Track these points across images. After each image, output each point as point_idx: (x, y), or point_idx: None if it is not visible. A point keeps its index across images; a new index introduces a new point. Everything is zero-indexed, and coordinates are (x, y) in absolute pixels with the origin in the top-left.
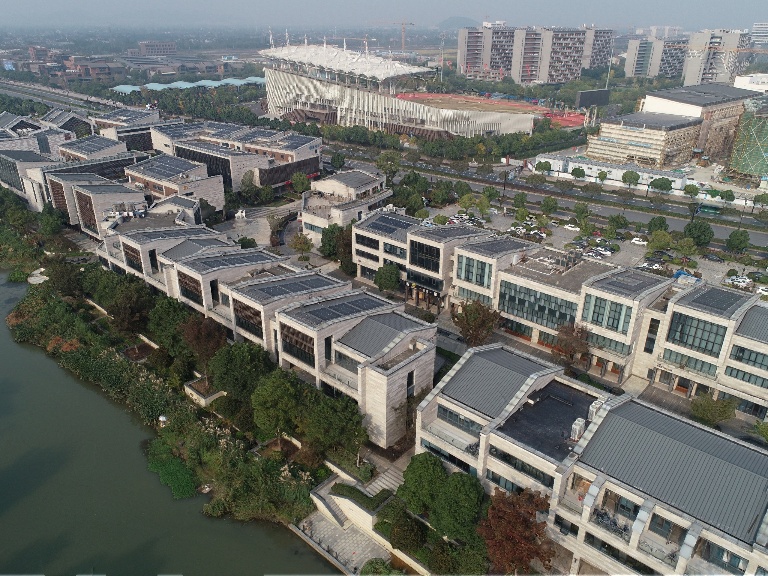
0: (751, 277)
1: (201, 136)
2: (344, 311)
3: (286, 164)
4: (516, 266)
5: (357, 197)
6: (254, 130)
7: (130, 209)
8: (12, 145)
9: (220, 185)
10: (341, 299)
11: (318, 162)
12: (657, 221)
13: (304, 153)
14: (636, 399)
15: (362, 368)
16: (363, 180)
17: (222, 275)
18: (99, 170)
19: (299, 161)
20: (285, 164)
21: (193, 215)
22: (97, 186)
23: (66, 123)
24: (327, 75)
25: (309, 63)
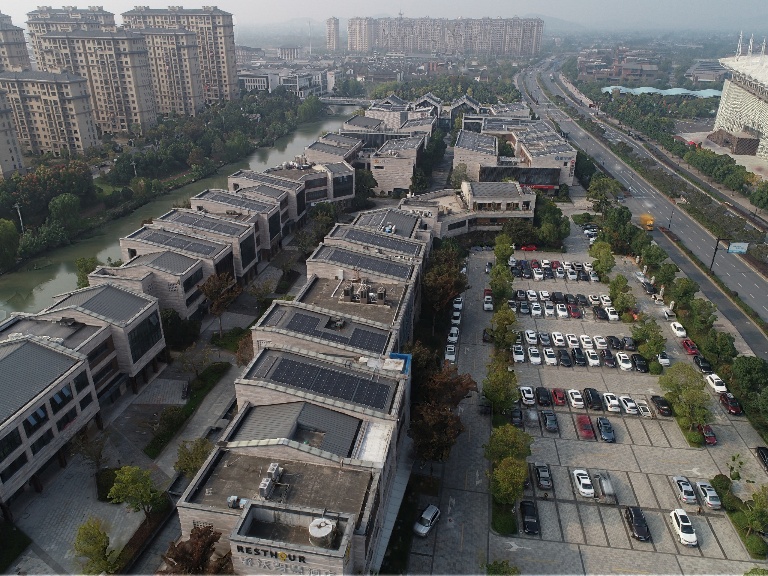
0: (725, 501)
1: (512, 132)
2: (172, 243)
3: (510, 167)
4: (339, 281)
5: (477, 205)
6: (552, 134)
7: (301, 162)
8: (383, 115)
9: (410, 167)
10: (200, 240)
11: (558, 175)
12: (745, 362)
13: (546, 162)
14: (81, 362)
15: (96, 268)
16: (502, 192)
17: (207, 205)
18: (381, 140)
19: (529, 168)
20: (509, 167)
21: (331, 178)
22: (330, 146)
23: (458, 107)
24: (767, 92)
25: (750, 76)
